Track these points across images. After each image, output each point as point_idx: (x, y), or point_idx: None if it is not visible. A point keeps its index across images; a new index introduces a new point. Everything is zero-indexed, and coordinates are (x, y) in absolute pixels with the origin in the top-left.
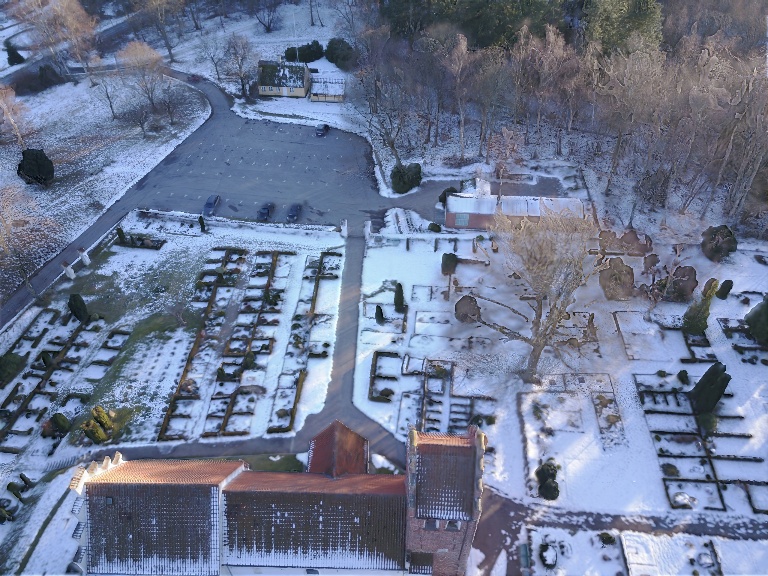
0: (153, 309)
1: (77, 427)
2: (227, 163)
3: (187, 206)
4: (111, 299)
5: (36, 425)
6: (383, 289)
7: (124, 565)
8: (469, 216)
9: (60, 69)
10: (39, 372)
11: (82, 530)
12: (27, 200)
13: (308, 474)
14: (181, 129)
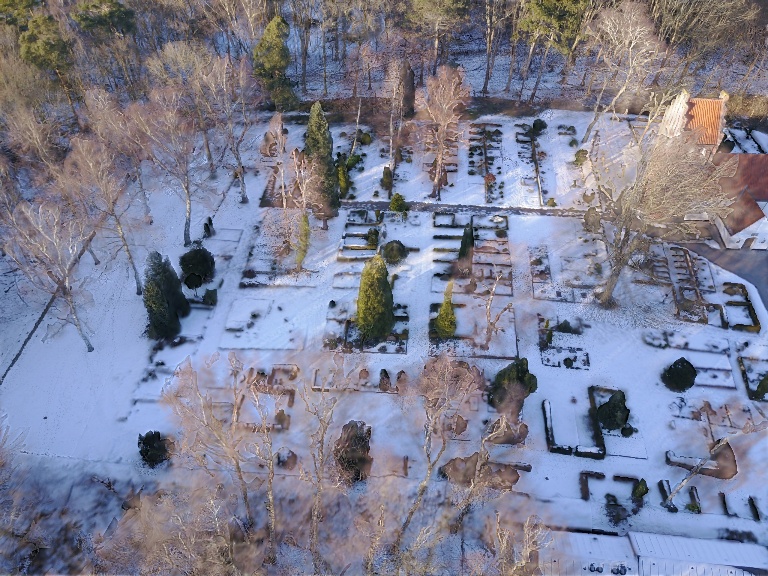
0: None
1: None
2: None
3: None
4: None
5: None
6: None
7: None
8: None
9: None
10: None
11: None
12: None
13: (764, 197)
14: None
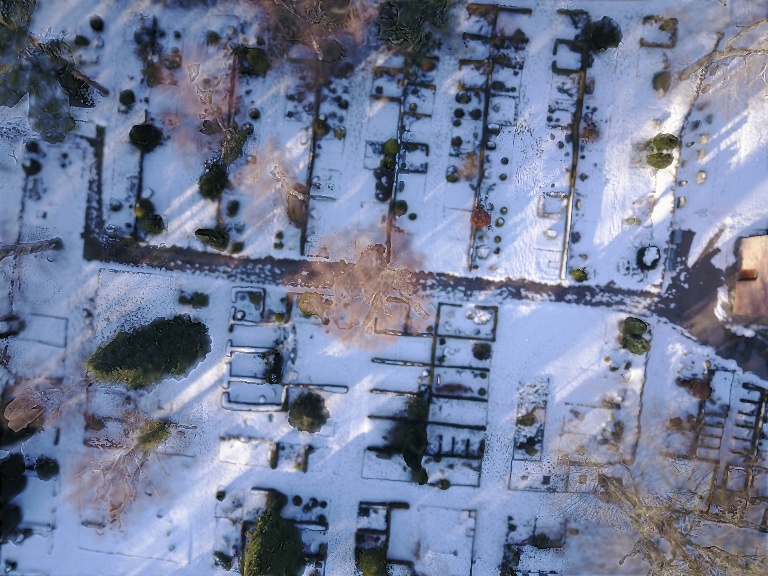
0: None
1: None
2: None
3: None
4: None
5: None
6: None
7: None
8: None
9: None
10: None
11: None
12: None
13: None
14: None
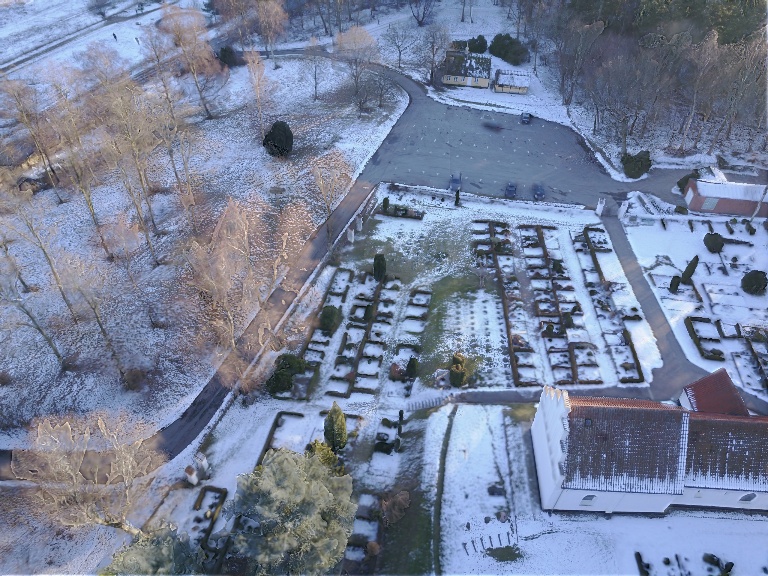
0: (443, 272)
1: (425, 373)
2: (449, 144)
3: (430, 182)
4: (397, 262)
5: (379, 370)
6: (659, 263)
7: (596, 482)
8: (718, 201)
9: (243, 51)
10: (358, 324)
11: (566, 447)
12: (271, 170)
13: (717, 413)
14: (390, 111)
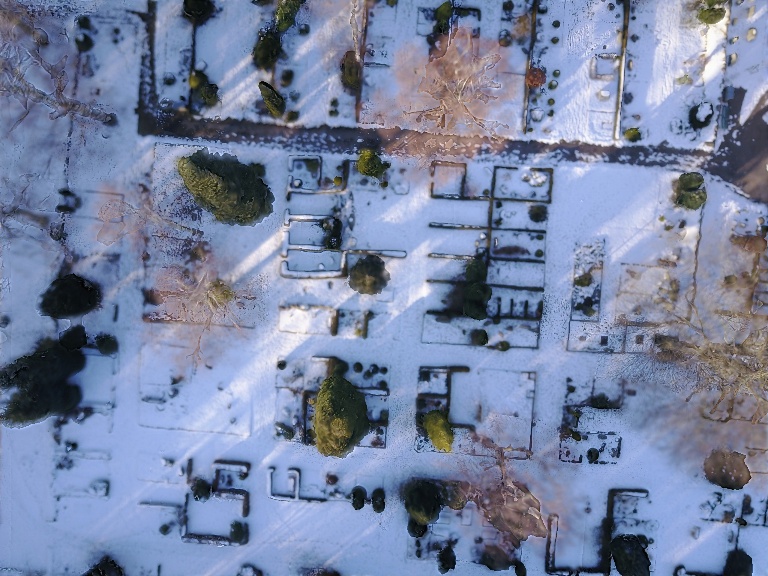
0: None
1: None
2: None
3: None
4: None
5: None
6: None
7: None
8: None
9: None
10: None
11: None
12: None
13: None
14: None
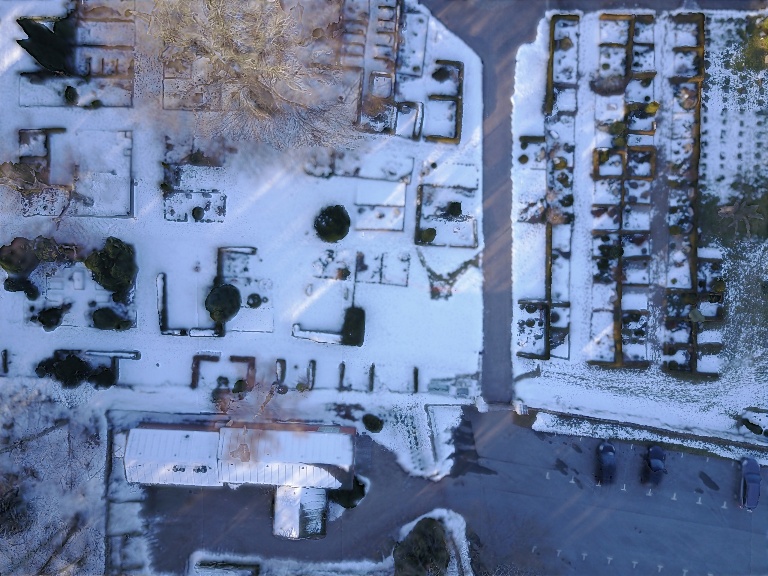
0: None
1: None
2: None
3: None
4: None
5: None
6: (451, 279)
7: None
8: None
9: None
10: None
11: None
12: None
13: None
14: None
